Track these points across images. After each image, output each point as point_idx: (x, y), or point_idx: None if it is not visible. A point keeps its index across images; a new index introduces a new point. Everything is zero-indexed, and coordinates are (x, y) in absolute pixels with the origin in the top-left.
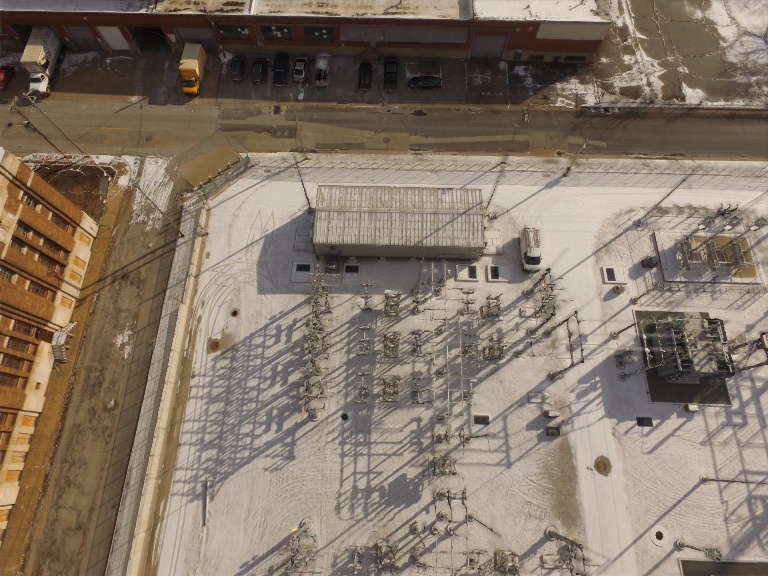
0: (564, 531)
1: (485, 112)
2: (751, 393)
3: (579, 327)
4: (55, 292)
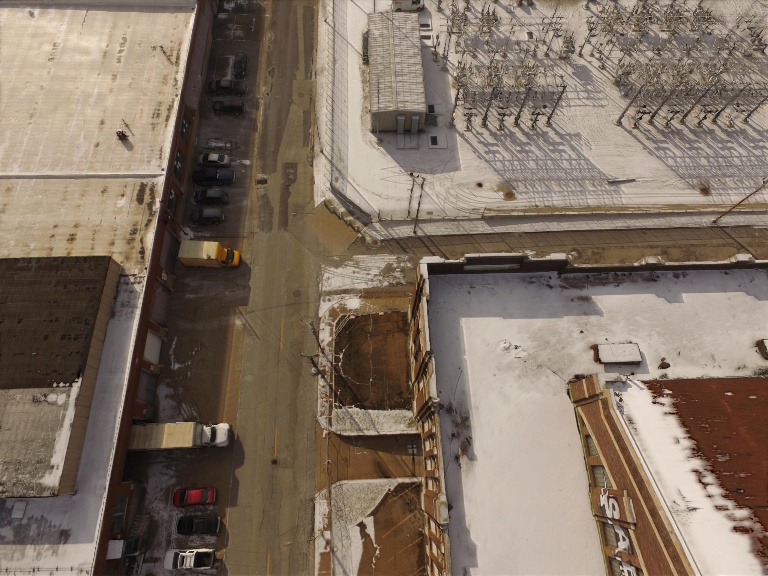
0: (583, 2)
1: (273, 30)
2: None
3: None
4: None
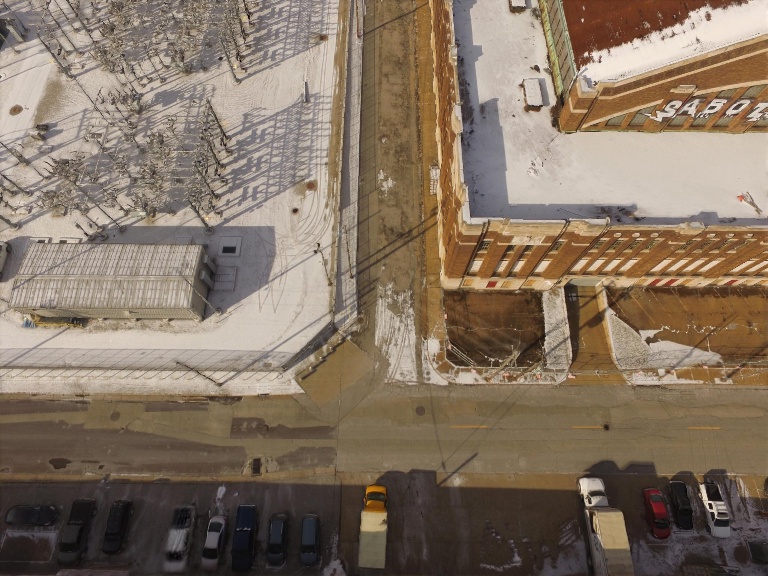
0: (62, 79)
1: None
2: None
3: None
4: None
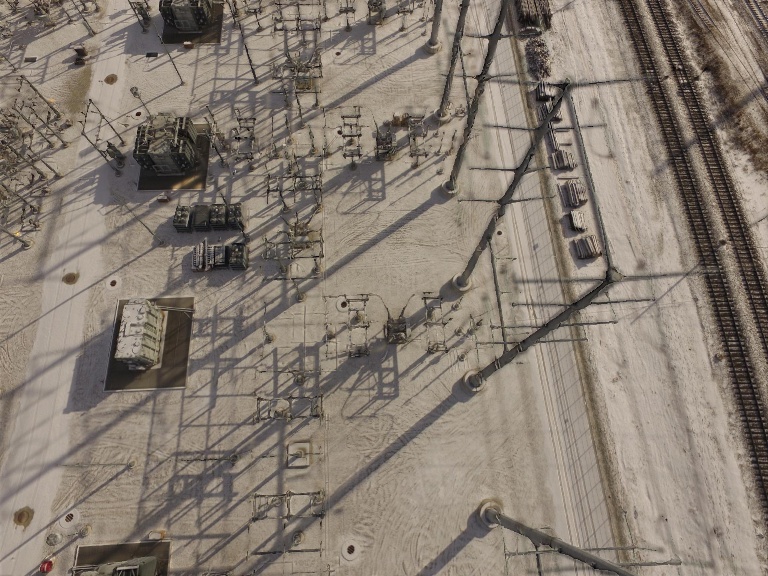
0: (69, 115)
1: None
2: (239, 37)
3: (123, 5)
4: None
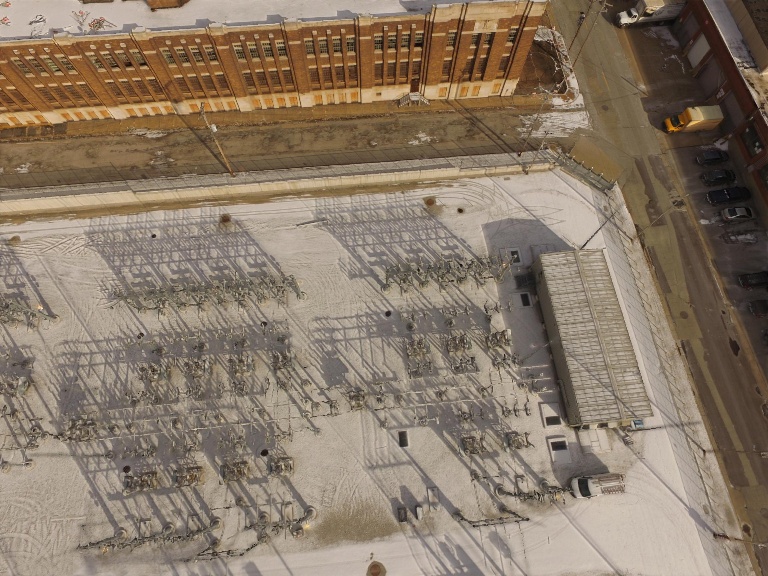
0: (313, 526)
1: None
2: None
3: (519, 548)
4: (448, 81)
